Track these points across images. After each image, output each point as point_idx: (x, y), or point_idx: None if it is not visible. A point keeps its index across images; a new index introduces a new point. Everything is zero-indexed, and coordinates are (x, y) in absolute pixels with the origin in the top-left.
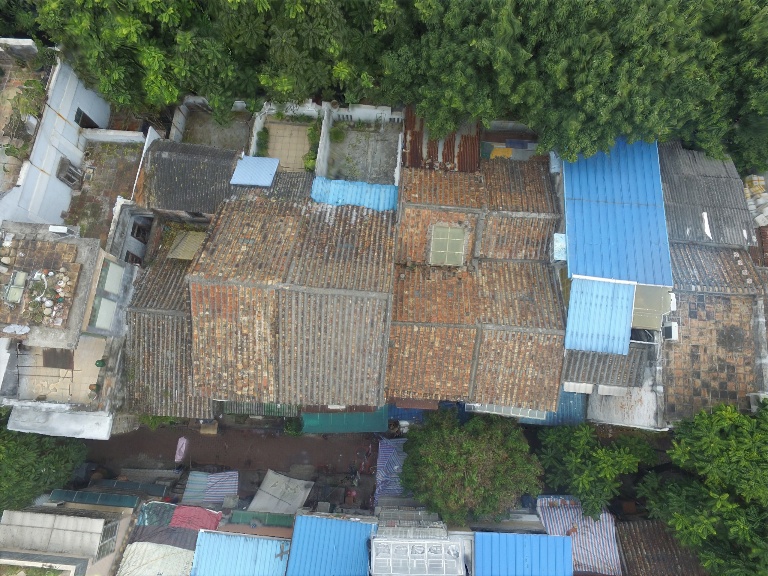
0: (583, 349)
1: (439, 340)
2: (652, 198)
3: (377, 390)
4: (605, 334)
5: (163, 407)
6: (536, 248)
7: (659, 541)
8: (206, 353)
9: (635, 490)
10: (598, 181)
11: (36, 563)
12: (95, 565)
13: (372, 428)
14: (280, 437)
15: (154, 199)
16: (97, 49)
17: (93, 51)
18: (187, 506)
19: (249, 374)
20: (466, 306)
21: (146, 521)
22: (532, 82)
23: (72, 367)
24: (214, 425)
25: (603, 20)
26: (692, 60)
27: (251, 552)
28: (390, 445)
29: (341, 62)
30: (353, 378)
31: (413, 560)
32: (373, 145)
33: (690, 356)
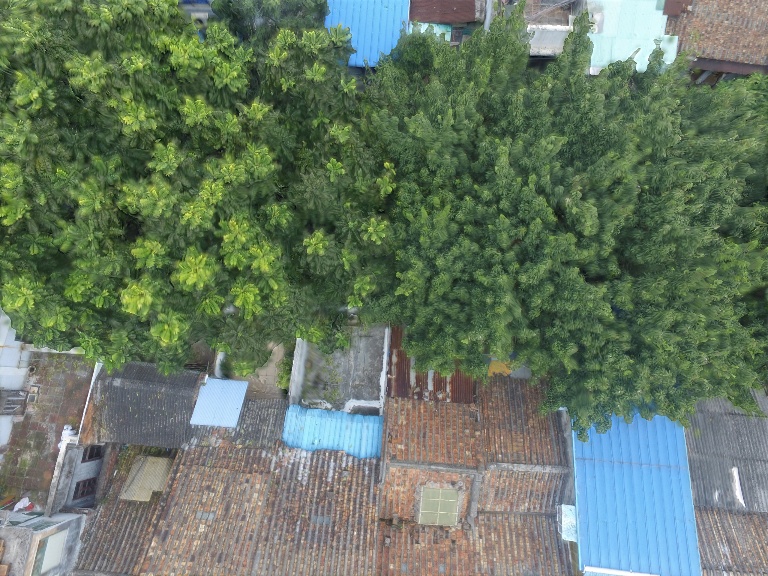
0: None
1: None
2: (675, 457)
3: None
4: None
5: None
6: (541, 501)
7: None
8: None
9: None
10: (612, 433)
11: None
12: None
13: None
14: None
15: (105, 431)
16: (23, 319)
17: (19, 322)
18: None
19: None
20: None
21: None
22: (535, 354)
23: None
24: None
25: (620, 308)
26: (726, 346)
27: None
28: None
29: (311, 324)
30: None
31: None
32: (356, 342)
33: None
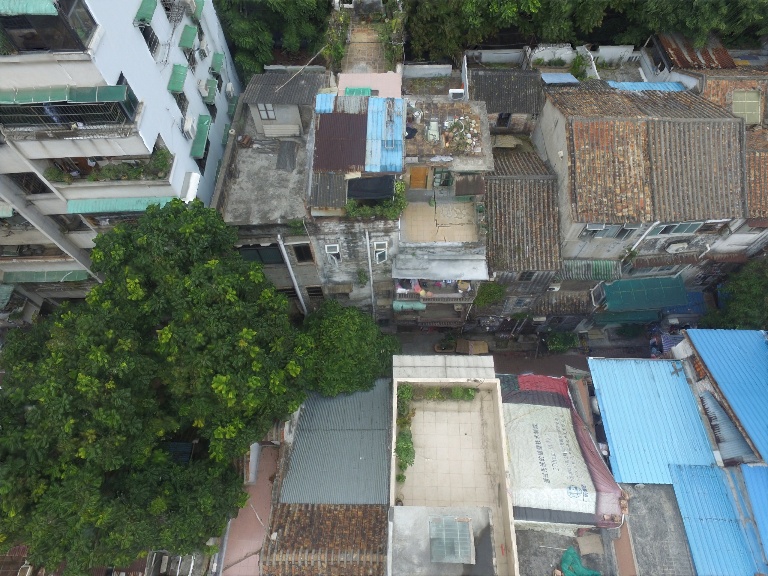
0: None
1: None
2: None
3: (741, 202)
4: None
5: (516, 262)
6: None
7: None
8: (588, 181)
9: None
10: None
11: (460, 379)
12: None
13: (674, 302)
14: (544, 357)
15: None
16: None
17: None
18: (528, 375)
19: (627, 197)
20: None
21: None
22: None
23: (484, 192)
24: (483, 345)
25: None
26: None
27: (646, 372)
28: (670, 340)
29: None
30: (718, 194)
31: None
32: (620, 76)
33: None
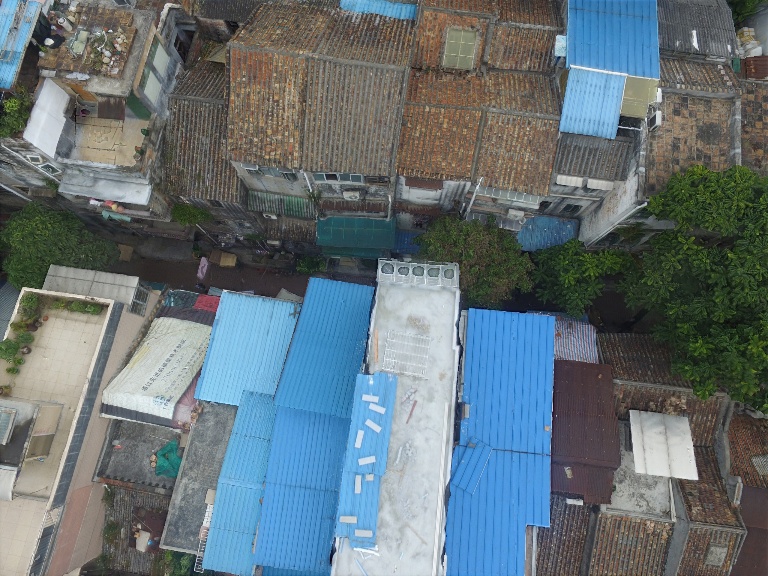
0: (575, 132)
1: (447, 121)
2: (647, 12)
3: (389, 160)
4: (596, 120)
5: (195, 189)
6: (540, 60)
7: (635, 348)
8: (240, 118)
9: (616, 287)
10: None
11: (80, 295)
12: (129, 315)
13: (380, 244)
14: (293, 276)
15: (198, 8)
16: None
17: None
18: (209, 295)
19: (277, 140)
20: (473, 97)
21: (172, 303)
22: None
23: (123, 118)
24: (233, 258)
25: None
26: None
27: (268, 310)
28: None
29: None
30: (369, 148)
31: (414, 277)
32: None
33: (671, 146)
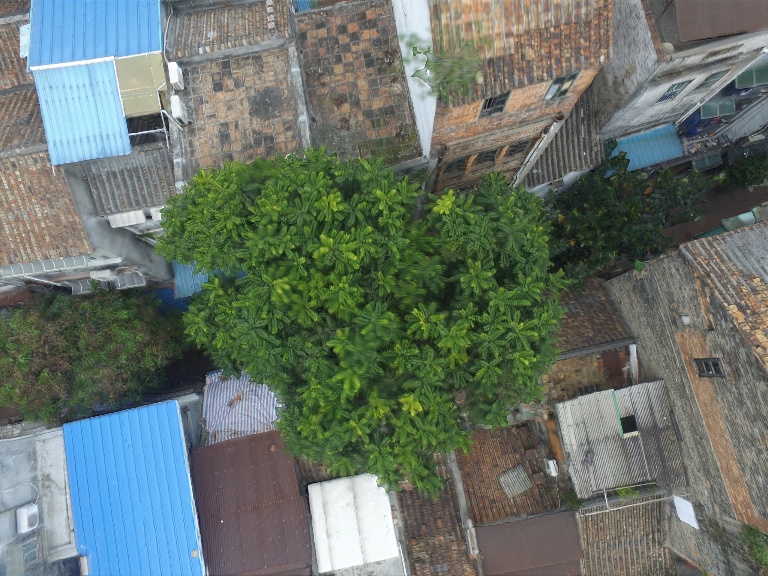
0: (75, 160)
1: None
2: None
3: None
4: (96, 134)
5: None
6: None
7: None
8: None
9: None
10: None
11: None
12: None
13: None
14: None
15: None
16: None
17: None
18: None
19: None
20: None
21: None
22: None
23: None
24: None
25: None
26: None
27: None
28: None
29: None
30: None
31: None
32: None
33: (218, 138)
